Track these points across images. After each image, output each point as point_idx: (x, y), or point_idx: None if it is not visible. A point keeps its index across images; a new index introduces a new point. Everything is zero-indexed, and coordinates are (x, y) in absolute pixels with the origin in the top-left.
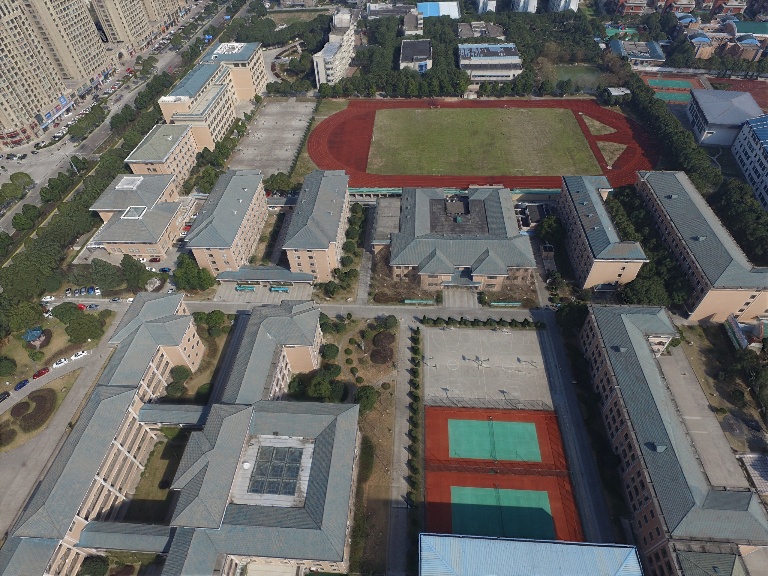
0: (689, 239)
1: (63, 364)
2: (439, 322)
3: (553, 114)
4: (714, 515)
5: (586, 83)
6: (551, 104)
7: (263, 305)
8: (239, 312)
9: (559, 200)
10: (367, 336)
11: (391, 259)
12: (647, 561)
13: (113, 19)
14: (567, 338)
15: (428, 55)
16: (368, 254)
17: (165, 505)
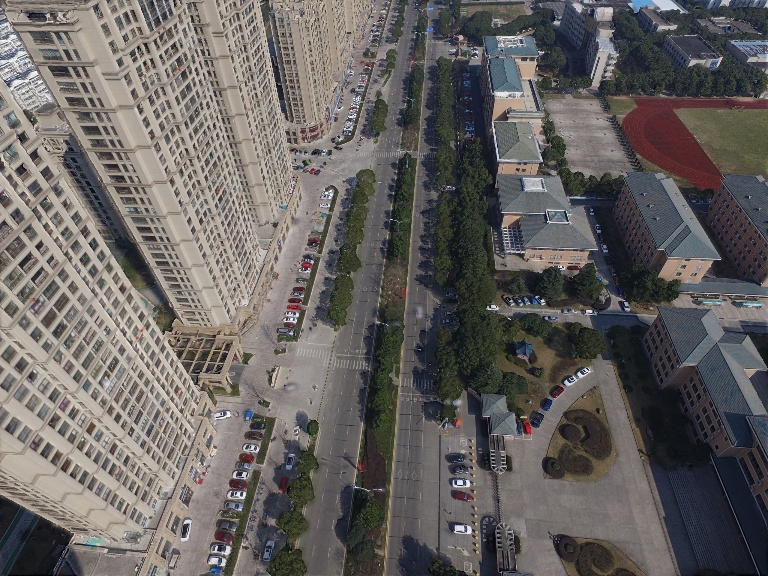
0: None
1: (574, 382)
2: None
3: None
4: None
5: None
6: None
7: (741, 321)
8: None
9: None
10: None
11: None
12: None
13: (345, 9)
14: None
15: (712, 52)
16: None
17: None
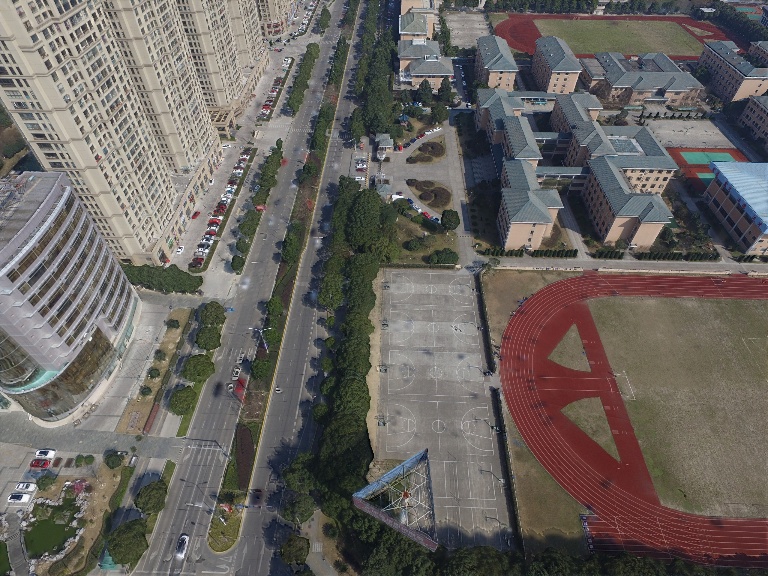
0: None
1: (431, 133)
2: (651, 116)
3: (664, 24)
4: None
5: (683, 5)
6: (659, 19)
7: (533, 111)
8: (521, 113)
9: (699, 62)
10: (612, 120)
11: (613, 83)
12: None
13: None
14: (730, 123)
15: None
16: (583, 90)
17: None
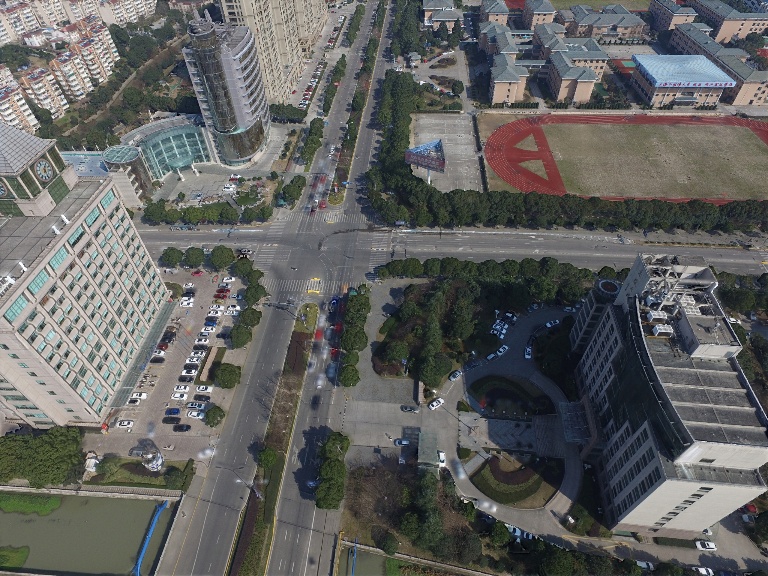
0: (715, 9)
1: (446, 54)
2: (605, 43)
3: None
4: (728, 50)
5: None
6: None
7: None
8: None
9: None
10: None
11: (579, 22)
12: None
13: None
14: (663, 46)
15: None
16: None
17: None
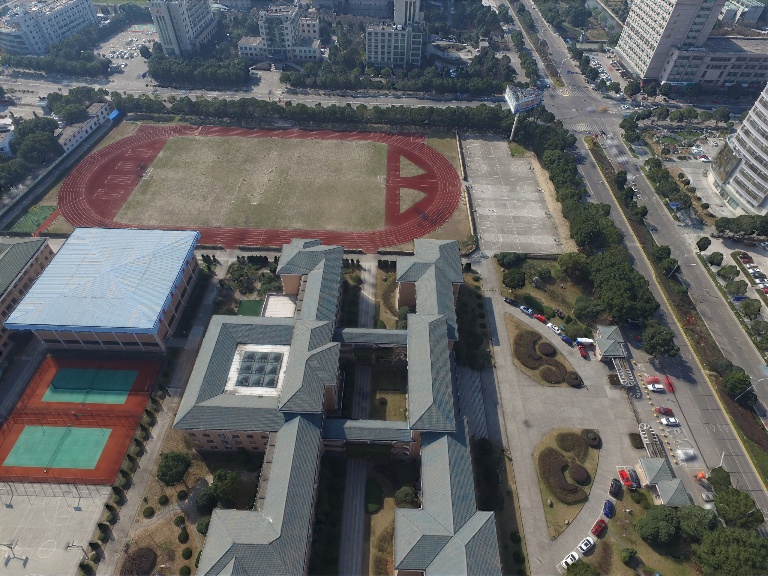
0: None
1: None
2: None
3: None
4: None
5: None
6: None
7: None
8: None
9: None
10: None
11: None
12: (3, 355)
13: None
14: None
15: None
16: None
17: (375, 387)
